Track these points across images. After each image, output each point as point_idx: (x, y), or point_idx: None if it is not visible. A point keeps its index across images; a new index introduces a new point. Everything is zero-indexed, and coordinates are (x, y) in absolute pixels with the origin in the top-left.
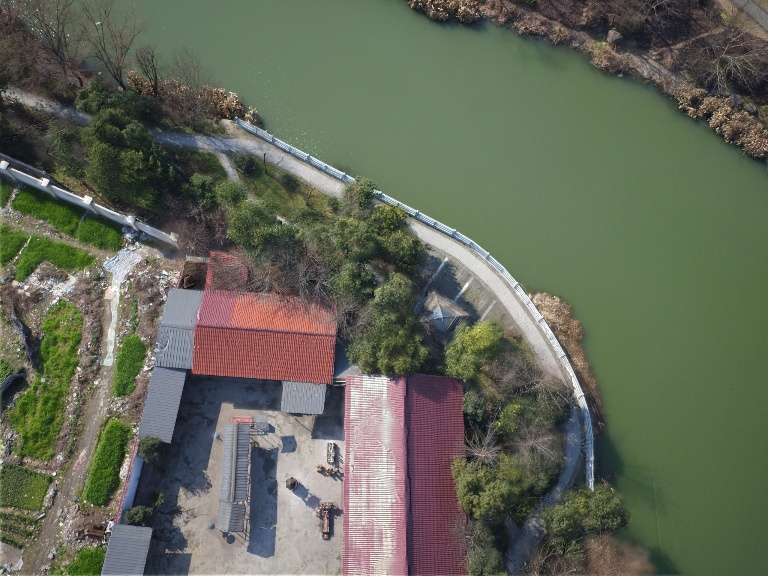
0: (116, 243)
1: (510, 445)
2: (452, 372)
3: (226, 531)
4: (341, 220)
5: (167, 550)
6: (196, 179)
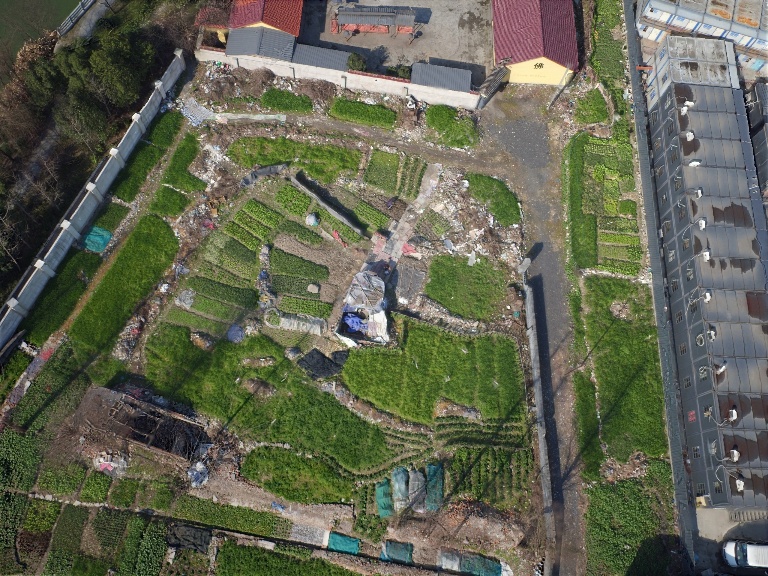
0: (176, 115)
1: None
2: None
3: None
4: None
5: None
6: None
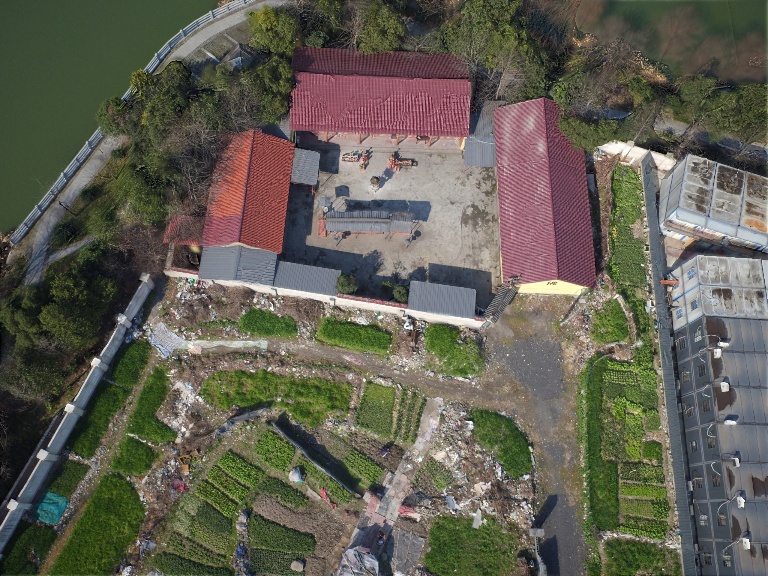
0: (143, 346)
1: (350, 7)
2: (289, 49)
3: (411, 236)
4: (144, 122)
5: None
6: (84, 256)
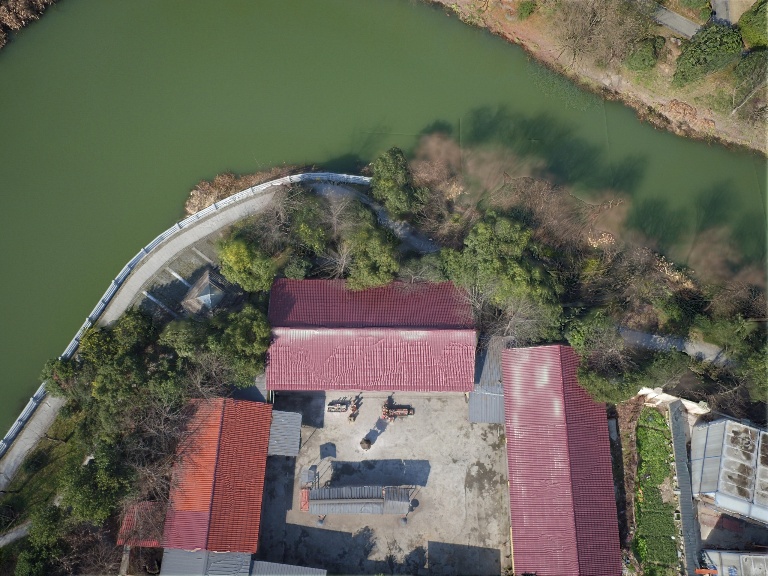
0: None
1: (336, 237)
2: (266, 287)
3: (408, 508)
4: (94, 394)
5: (425, 567)
6: (21, 571)
